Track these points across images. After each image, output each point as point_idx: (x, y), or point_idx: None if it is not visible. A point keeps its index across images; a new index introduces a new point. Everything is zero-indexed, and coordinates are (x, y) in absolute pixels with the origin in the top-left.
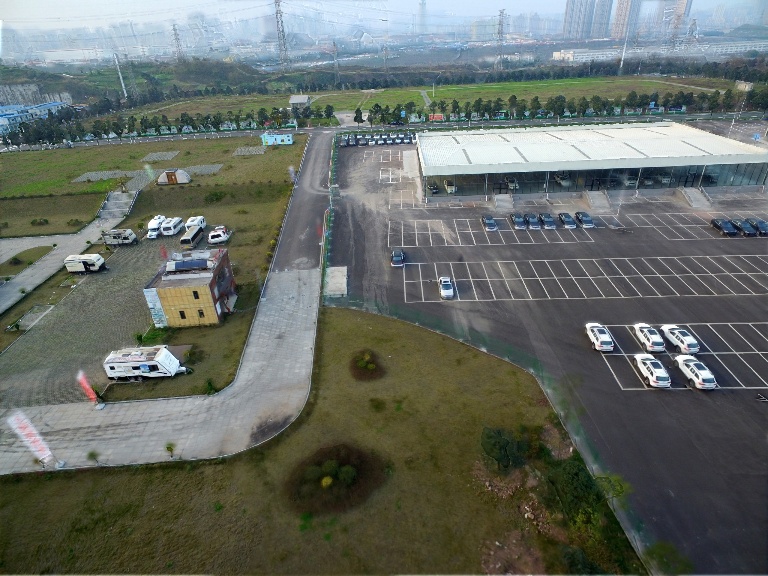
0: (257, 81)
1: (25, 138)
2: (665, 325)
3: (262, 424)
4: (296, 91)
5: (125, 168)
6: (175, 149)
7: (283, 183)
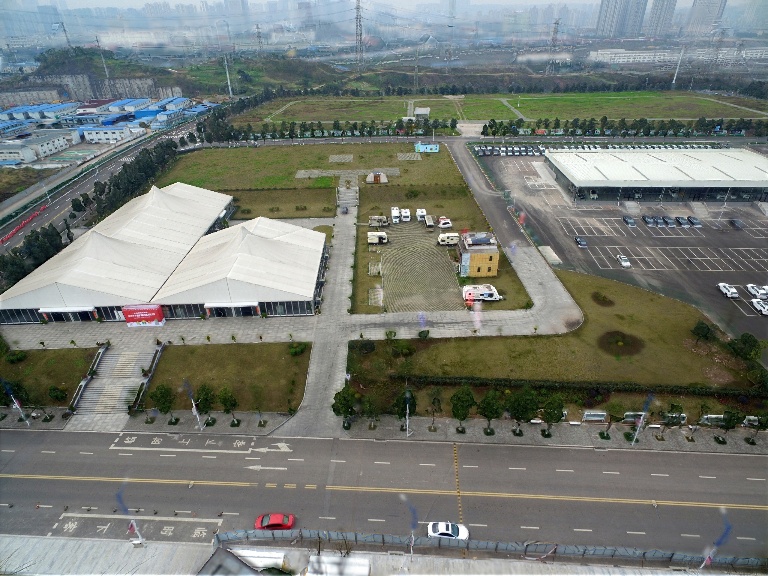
0: (339, 81)
1: (218, 138)
2: (765, 286)
3: (567, 322)
4: (384, 94)
5: (324, 168)
6: (347, 152)
7: (459, 186)
